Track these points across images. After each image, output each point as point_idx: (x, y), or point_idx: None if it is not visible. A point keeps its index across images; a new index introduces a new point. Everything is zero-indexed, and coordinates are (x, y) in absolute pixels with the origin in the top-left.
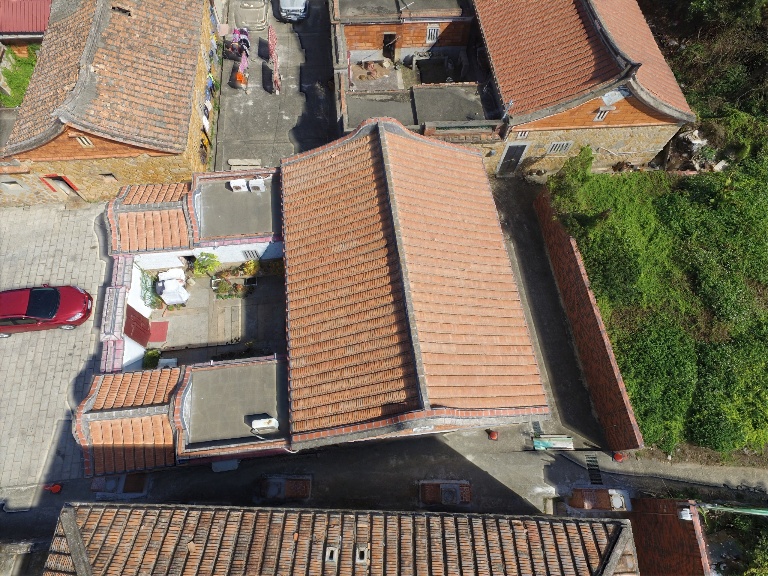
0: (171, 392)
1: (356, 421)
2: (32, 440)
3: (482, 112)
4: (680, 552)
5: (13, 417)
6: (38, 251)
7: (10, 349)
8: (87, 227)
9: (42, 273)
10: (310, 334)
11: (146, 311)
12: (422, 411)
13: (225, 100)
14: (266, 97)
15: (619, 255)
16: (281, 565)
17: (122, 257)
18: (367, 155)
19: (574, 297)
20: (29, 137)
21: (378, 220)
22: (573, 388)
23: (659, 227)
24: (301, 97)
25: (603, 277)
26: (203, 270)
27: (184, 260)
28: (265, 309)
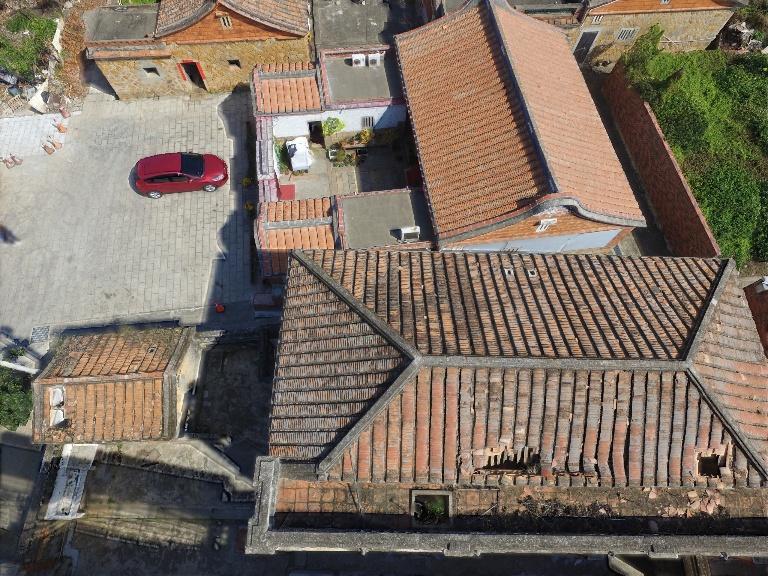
0: (328, 211)
1: (494, 216)
2: (193, 274)
3: (560, 2)
4: (759, 321)
5: (174, 258)
6: (172, 132)
7: (162, 207)
8: (212, 113)
9: (179, 149)
10: (442, 163)
11: (277, 174)
12: (557, 193)
13: (318, 10)
14: (354, 7)
15: (688, 113)
16: (473, 277)
17: (264, 119)
18: (477, 22)
19: (648, 154)
20: (178, 19)
21: (494, 70)
22: (649, 229)
23: (719, 94)
24: (385, 7)
25: (675, 131)
26: (333, 130)
27: (309, 129)
28: (376, 174)
